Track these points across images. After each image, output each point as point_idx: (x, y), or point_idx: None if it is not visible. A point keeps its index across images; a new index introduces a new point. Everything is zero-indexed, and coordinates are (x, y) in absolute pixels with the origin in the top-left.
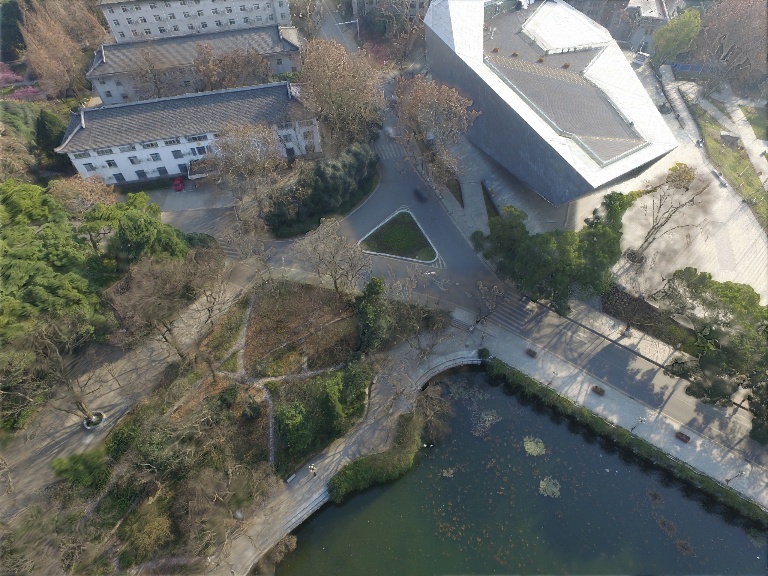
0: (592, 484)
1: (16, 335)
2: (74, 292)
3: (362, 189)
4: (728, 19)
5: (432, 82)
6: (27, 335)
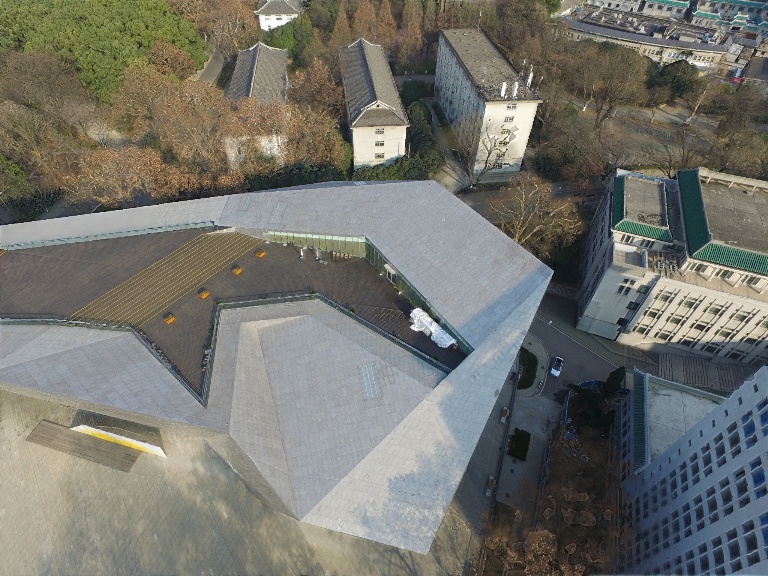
0: None
1: (62, 53)
2: (88, 65)
3: None
4: None
5: None
6: (62, 56)
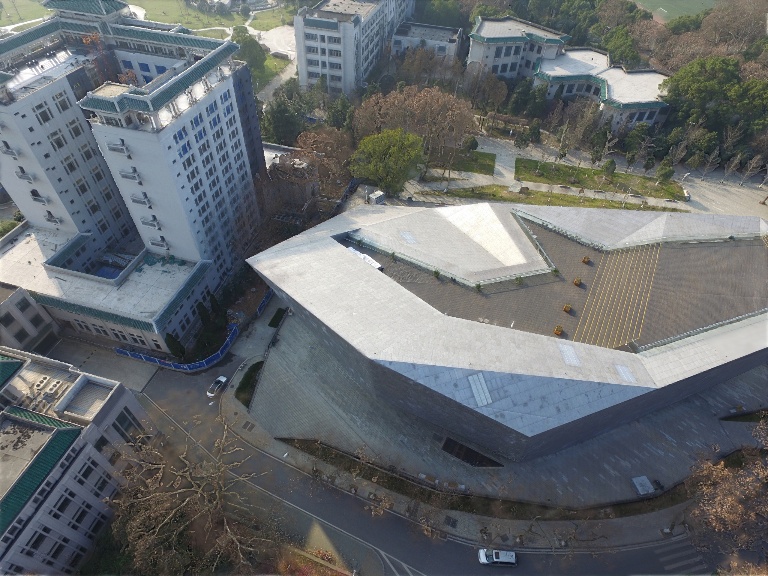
0: None
1: None
2: None
3: None
4: (459, 118)
5: None
6: None
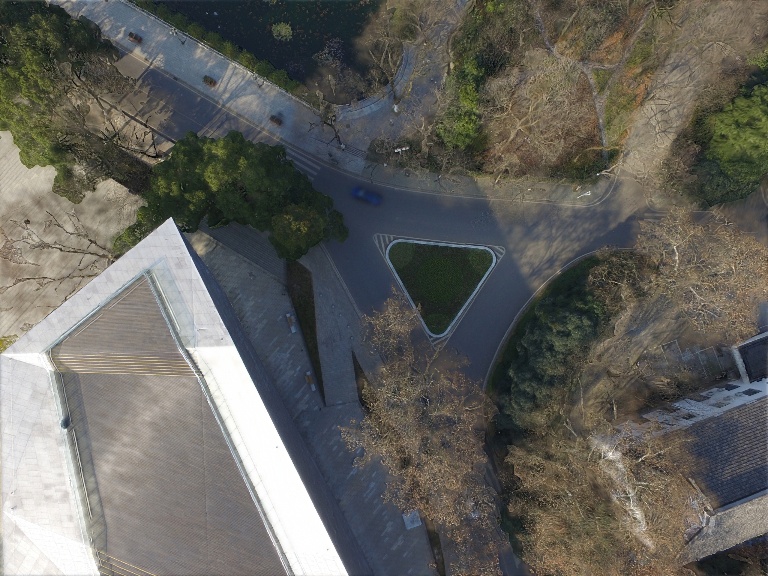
0: (233, 0)
1: None
2: None
3: (508, 366)
4: None
5: (440, 463)
6: None
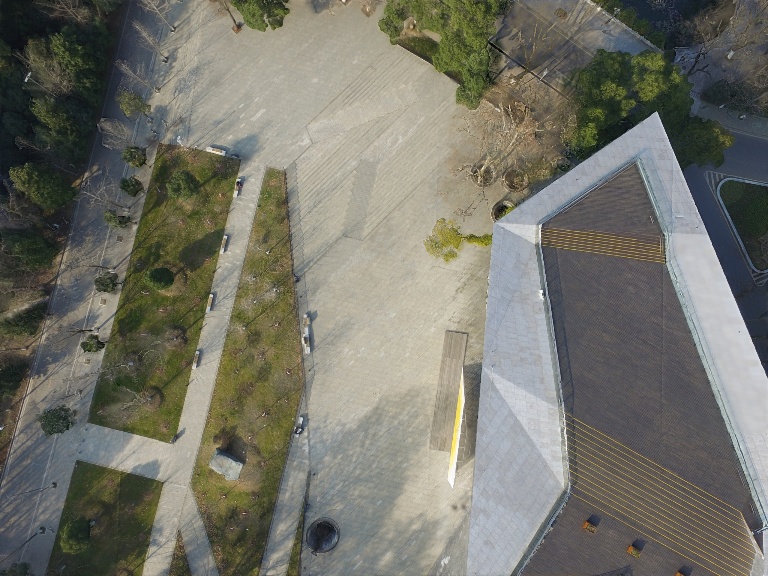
0: None
1: None
2: None
3: None
4: None
5: None
6: None
